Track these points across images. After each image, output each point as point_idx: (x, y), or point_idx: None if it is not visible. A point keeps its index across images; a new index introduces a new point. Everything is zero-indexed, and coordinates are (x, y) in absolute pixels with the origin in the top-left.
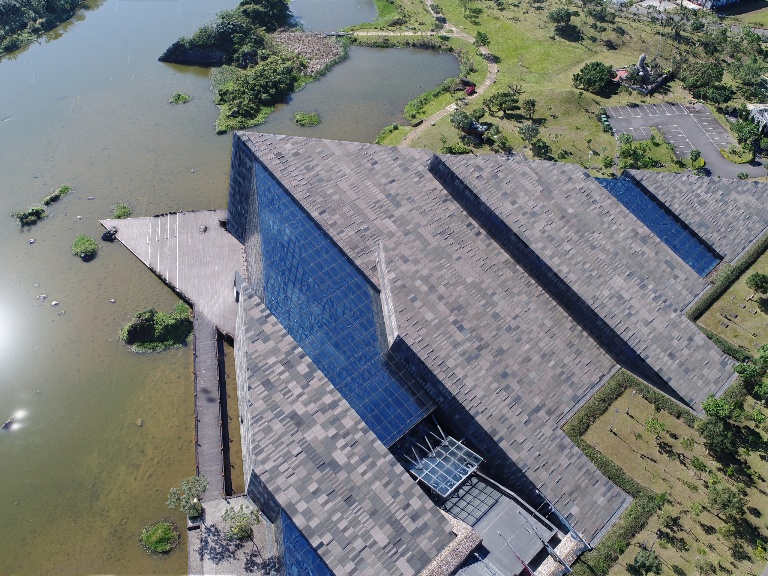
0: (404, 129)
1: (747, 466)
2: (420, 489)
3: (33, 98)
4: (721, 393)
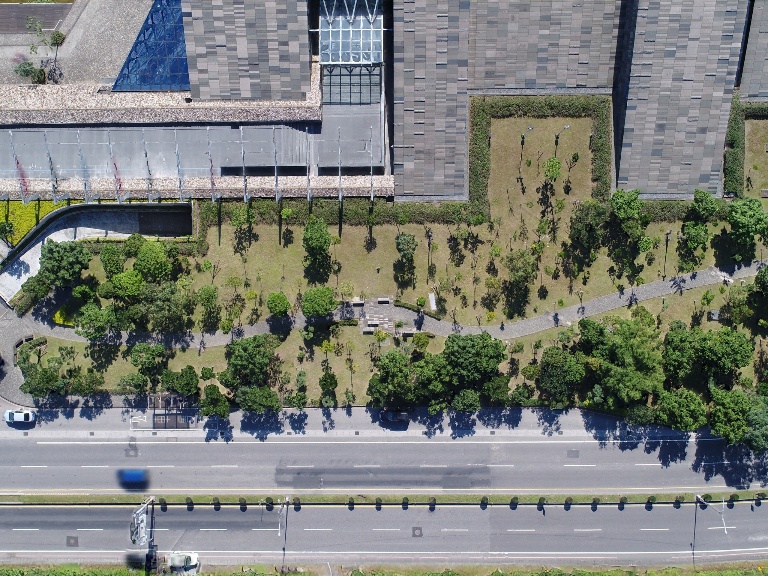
0: None
1: (589, 263)
2: (307, 39)
3: None
4: (662, 197)
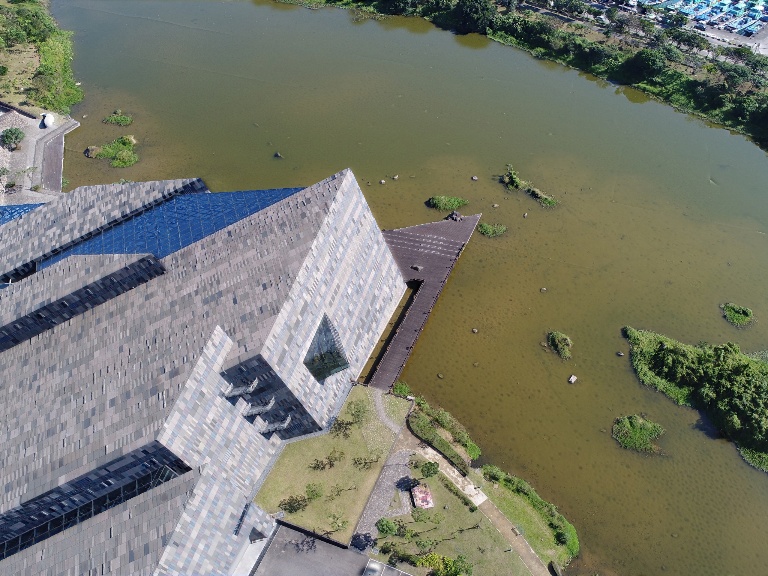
0: (550, 546)
1: None
2: None
3: (762, 201)
4: None
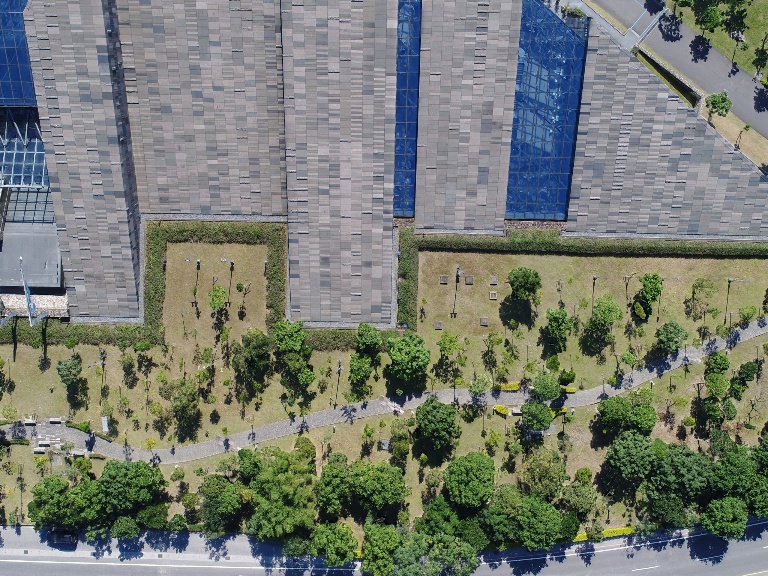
0: None
1: (262, 389)
2: None
3: None
4: (336, 326)
